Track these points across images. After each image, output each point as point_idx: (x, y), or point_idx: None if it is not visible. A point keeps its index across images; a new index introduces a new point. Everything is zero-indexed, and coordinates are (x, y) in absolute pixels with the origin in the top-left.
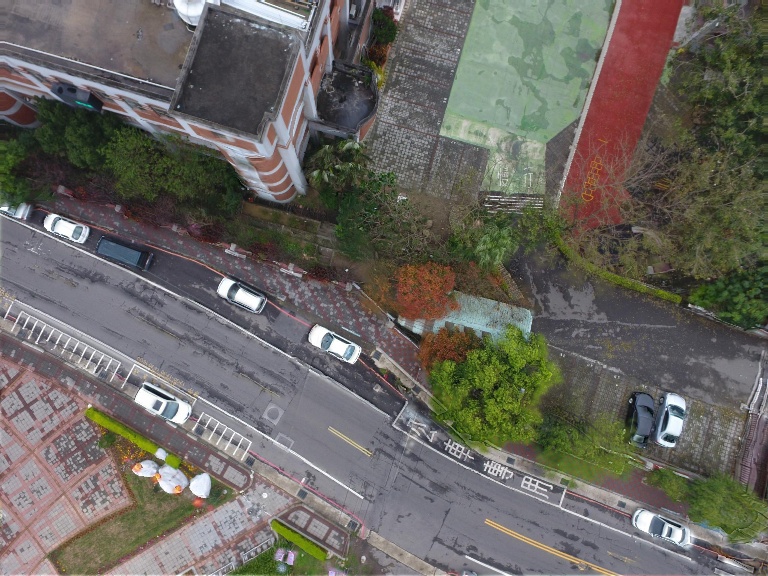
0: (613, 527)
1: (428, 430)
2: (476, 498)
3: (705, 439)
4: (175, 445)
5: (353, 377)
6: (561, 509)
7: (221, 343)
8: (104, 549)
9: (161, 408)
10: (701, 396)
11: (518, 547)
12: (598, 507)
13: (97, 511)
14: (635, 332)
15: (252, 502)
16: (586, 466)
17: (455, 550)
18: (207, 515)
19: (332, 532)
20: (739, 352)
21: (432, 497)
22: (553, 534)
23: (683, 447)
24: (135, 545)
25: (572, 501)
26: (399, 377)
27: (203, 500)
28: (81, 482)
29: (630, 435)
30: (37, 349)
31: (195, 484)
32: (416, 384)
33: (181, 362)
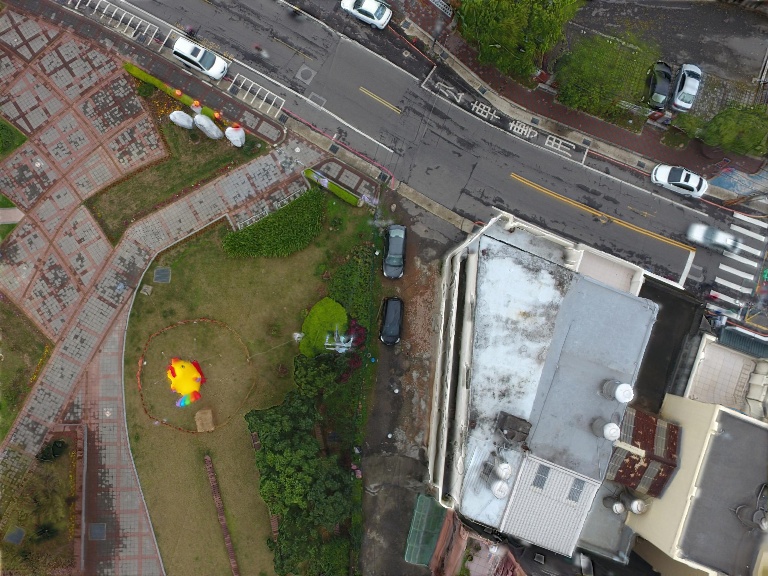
0: (633, 184)
1: (456, 91)
2: (502, 153)
3: (719, 109)
4: (211, 102)
5: (383, 43)
6: (583, 166)
7: (256, 10)
8: (140, 196)
9: (199, 55)
10: (715, 71)
11: (543, 200)
12: (619, 166)
13: (133, 161)
14: (652, 13)
15: (285, 155)
16: (607, 127)
17: (482, 201)
18: (241, 167)
19: (363, 181)
20: (750, 31)
21: (460, 151)
22: (576, 189)
23: (699, 116)
24: (170, 193)
25: (594, 160)
26: (428, 44)
27: (237, 153)
28: (118, 134)
29: (649, 96)
30: (77, 13)
31: (231, 129)
32: (444, 50)
33: (217, 27)
